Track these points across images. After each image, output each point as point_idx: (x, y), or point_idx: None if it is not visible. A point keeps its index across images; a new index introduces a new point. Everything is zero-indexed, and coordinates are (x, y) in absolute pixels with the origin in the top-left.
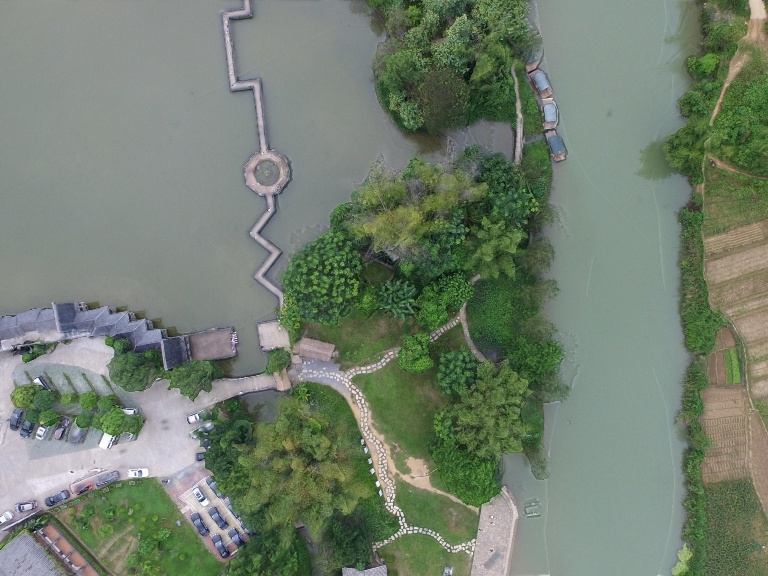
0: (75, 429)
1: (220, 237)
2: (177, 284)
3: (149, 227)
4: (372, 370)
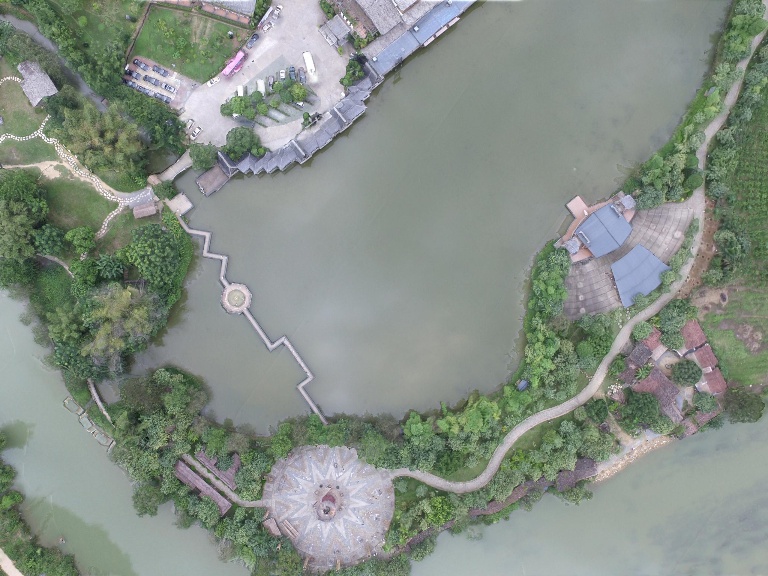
0: (262, 88)
1: (245, 246)
2: (255, 204)
3: (290, 229)
4: (110, 216)
